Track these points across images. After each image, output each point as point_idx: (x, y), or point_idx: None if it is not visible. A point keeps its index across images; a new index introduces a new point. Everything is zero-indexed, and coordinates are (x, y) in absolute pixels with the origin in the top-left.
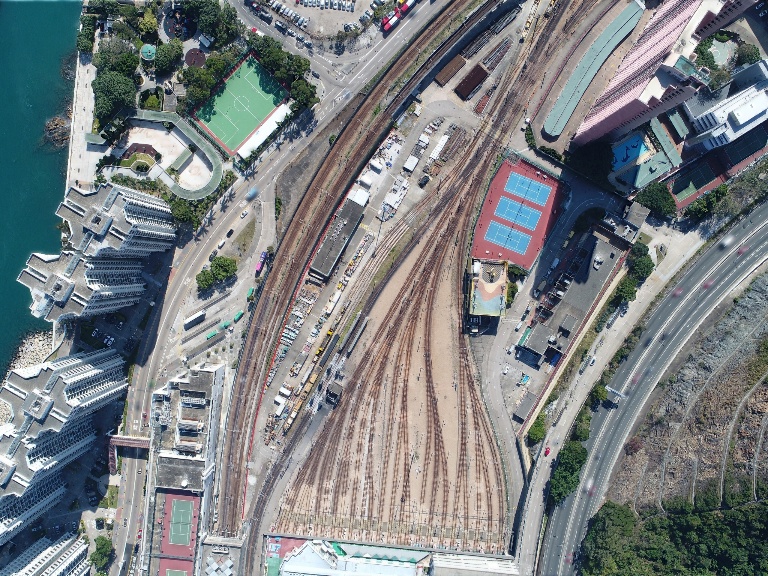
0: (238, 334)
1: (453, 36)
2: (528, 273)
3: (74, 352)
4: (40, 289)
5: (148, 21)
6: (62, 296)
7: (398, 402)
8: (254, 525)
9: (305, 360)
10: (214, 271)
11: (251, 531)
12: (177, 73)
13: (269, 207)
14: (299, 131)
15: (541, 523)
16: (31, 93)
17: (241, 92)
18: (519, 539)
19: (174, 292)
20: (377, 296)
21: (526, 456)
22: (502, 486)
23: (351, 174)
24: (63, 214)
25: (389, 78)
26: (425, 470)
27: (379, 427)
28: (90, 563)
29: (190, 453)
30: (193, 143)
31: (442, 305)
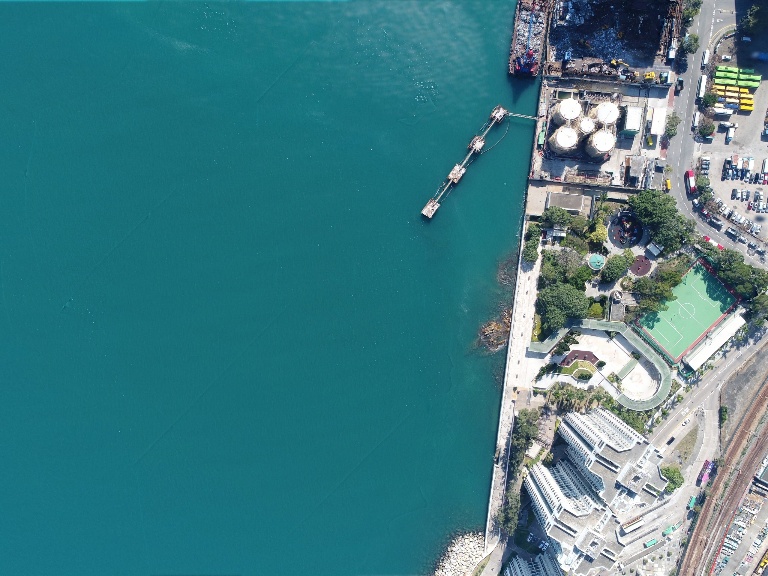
0: (676, 542)
1: None
2: None
3: (507, 555)
4: (569, 543)
5: (601, 233)
6: (598, 554)
7: None
8: None
9: (746, 570)
10: None
11: None
12: (621, 280)
13: (712, 415)
14: (747, 339)
15: None
16: (468, 298)
17: (687, 299)
18: None
19: None
20: None
21: None
22: None
23: None
24: (595, 469)
25: None
26: None
27: None
28: None
29: None
30: (636, 350)
31: None
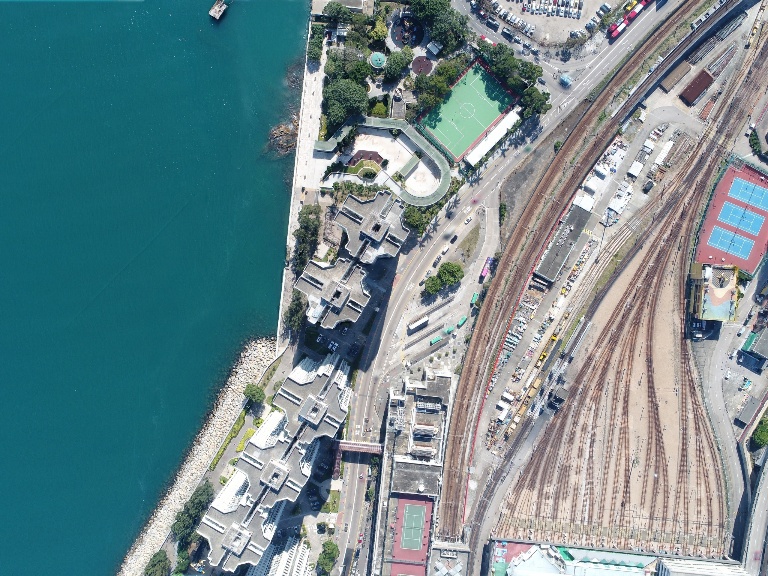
0: (461, 339)
1: (683, 42)
2: (751, 278)
3: (298, 358)
4: (316, 296)
5: (380, 29)
6: (341, 303)
7: (619, 407)
8: (474, 530)
9: (527, 365)
10: (443, 277)
11: (471, 536)
12: (404, 80)
13: (493, 213)
14: (524, 137)
15: (767, 528)
16: (257, 101)
17: (467, 99)
18: (745, 544)
19: (398, 298)
20: (600, 301)
21: (748, 461)
22: (722, 491)
23: (578, 180)
24: (340, 221)
25: (614, 84)
26: (646, 475)
27: (600, 432)
28: (312, 568)
29: (423, 458)
30: (419, 150)
31: (664, 310)
